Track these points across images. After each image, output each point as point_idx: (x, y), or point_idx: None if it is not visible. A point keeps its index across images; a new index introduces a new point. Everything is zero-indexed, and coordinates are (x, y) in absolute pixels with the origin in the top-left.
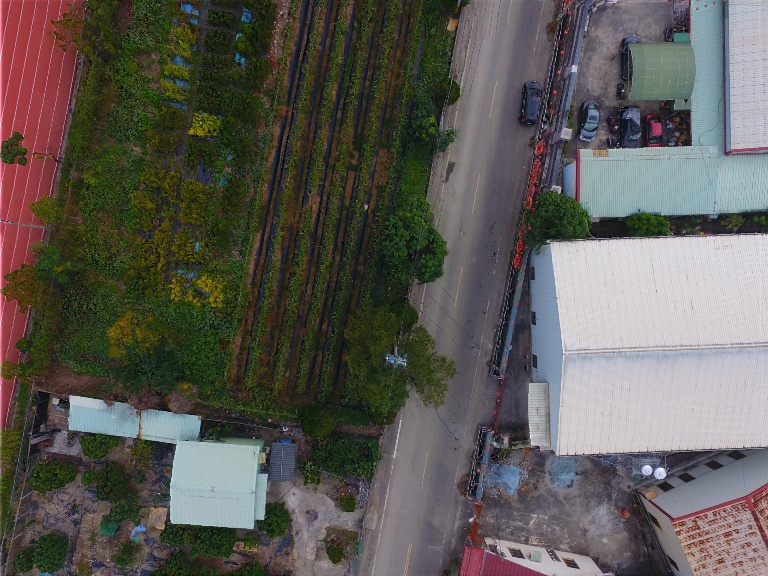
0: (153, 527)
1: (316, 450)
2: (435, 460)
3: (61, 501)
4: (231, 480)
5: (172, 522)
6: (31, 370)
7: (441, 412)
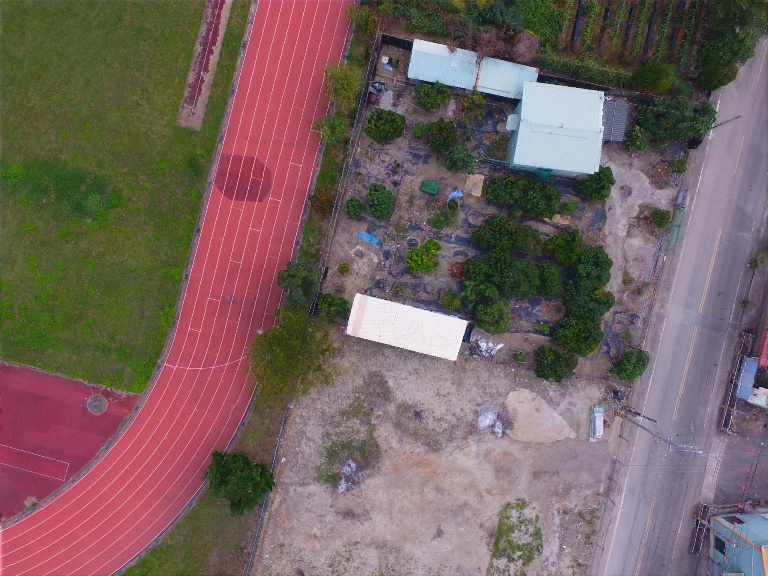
0: (469, 194)
1: (652, 107)
2: (750, 144)
3: (382, 161)
4: (579, 119)
5: (515, 162)
6: (384, 6)
7: (760, 95)
